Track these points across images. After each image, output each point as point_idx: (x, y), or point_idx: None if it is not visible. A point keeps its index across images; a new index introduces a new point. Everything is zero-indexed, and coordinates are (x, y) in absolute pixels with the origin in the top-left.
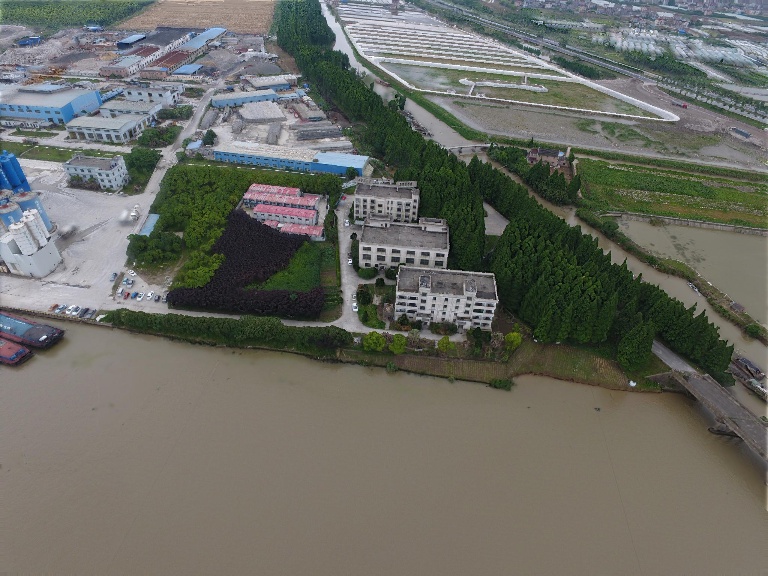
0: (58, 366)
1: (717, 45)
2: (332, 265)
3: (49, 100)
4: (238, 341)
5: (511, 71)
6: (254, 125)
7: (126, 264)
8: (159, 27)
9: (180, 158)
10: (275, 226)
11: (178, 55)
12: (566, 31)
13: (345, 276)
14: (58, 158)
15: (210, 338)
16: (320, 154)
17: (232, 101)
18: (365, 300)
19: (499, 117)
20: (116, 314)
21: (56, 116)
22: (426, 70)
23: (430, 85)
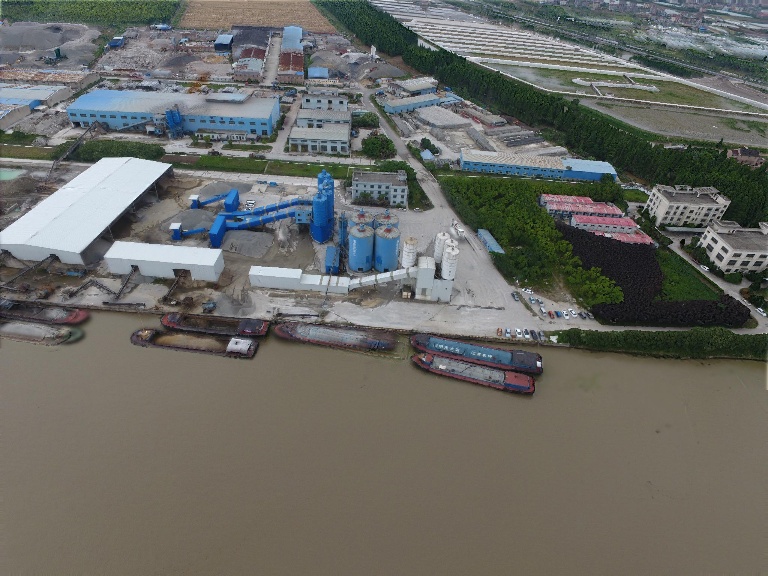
0: (572, 391)
1: (743, 42)
2: (693, 272)
3: (248, 110)
4: (701, 352)
5: (608, 71)
6: (448, 132)
7: (509, 282)
8: (234, 26)
9: (431, 169)
10: (604, 236)
11: (295, 57)
12: (609, 29)
13: (715, 282)
14: (307, 173)
15: (673, 351)
16: (565, 161)
17: (406, 107)
18: (767, 304)
19: (652, 118)
20: (575, 334)
21: (261, 127)
22: (530, 70)
23: (553, 86)
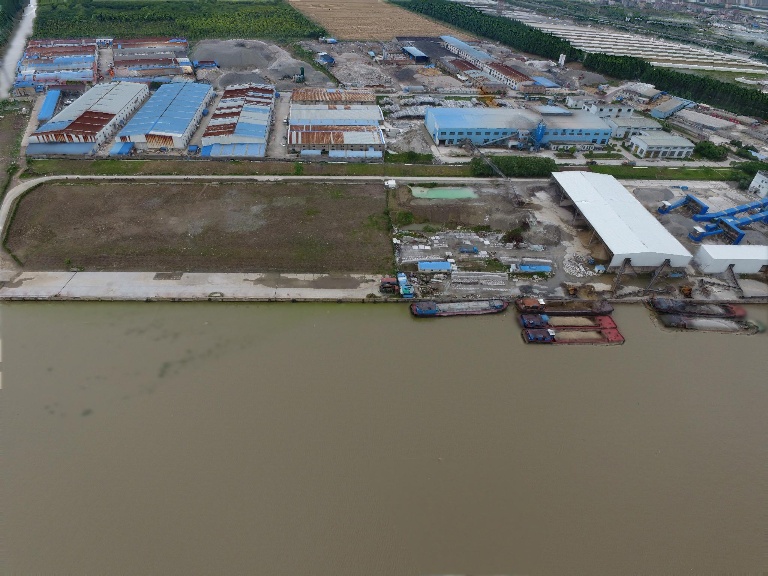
0: None
1: None
2: None
3: (586, 122)
4: None
5: None
6: None
7: None
8: (397, 37)
9: None
10: None
11: None
12: None
13: None
14: (692, 177)
15: None
16: None
17: None
18: None
19: None
20: None
21: (602, 137)
22: (689, 72)
23: None
